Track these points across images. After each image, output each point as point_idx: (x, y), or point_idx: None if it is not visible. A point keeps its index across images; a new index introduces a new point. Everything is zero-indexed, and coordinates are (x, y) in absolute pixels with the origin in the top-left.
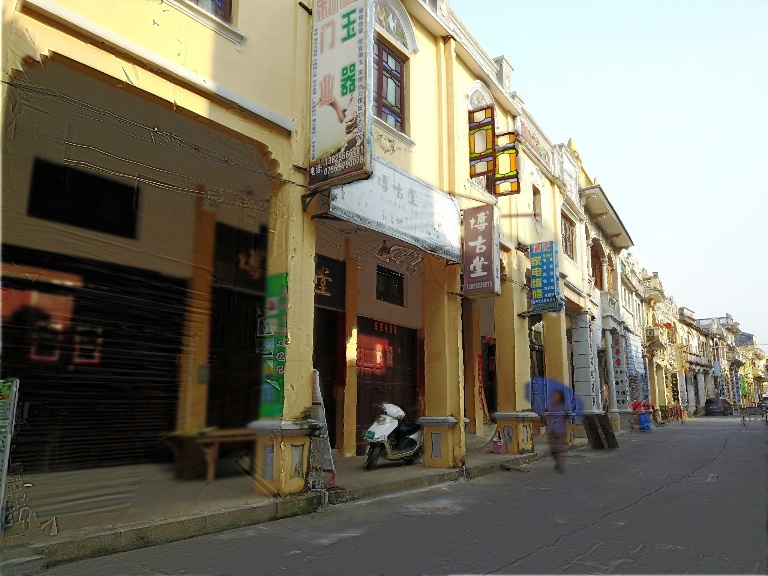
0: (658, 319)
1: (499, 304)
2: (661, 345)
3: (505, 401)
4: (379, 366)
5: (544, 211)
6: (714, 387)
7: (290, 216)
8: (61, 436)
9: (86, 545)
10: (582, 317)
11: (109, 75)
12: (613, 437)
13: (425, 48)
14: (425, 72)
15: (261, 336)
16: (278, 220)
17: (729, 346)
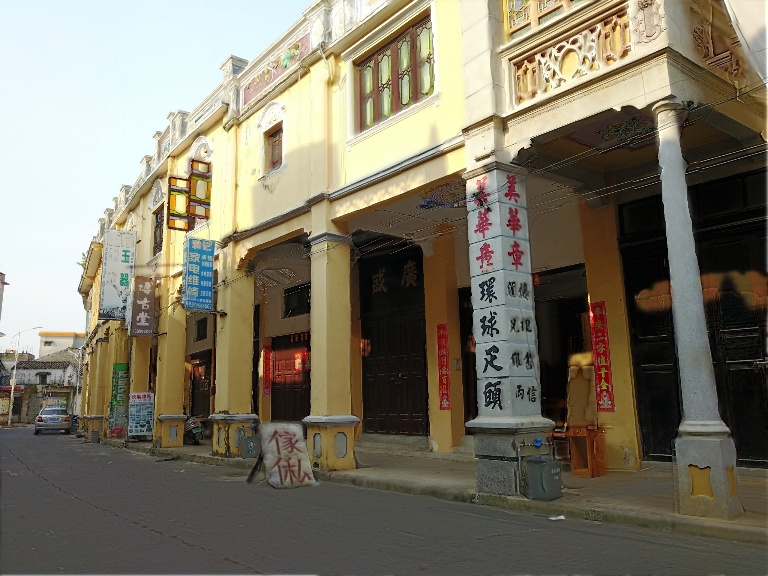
0: None
1: None
2: None
3: None
4: (297, 372)
5: (289, 138)
6: None
7: None
8: None
9: None
10: None
11: None
12: None
13: None
14: None
15: None
16: None
17: None
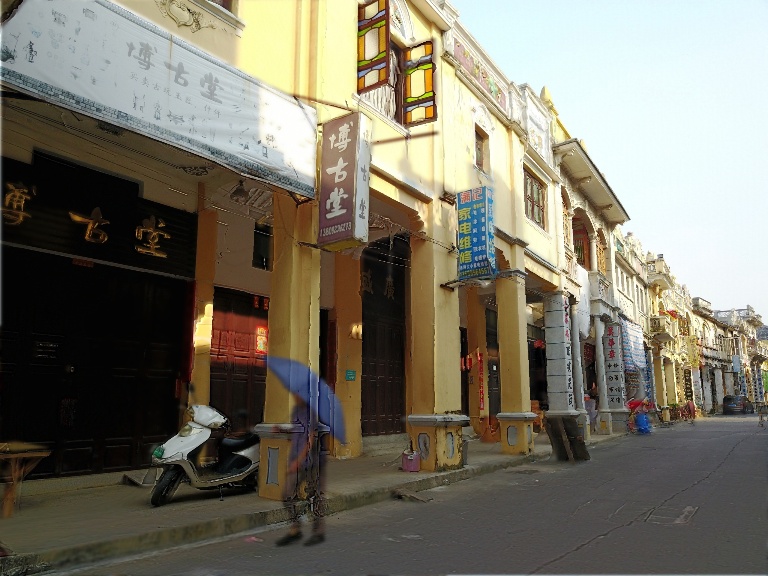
0: (667, 308)
1: (417, 272)
2: (667, 336)
3: (421, 400)
4: (261, 355)
5: (494, 161)
6: (733, 383)
7: None
8: None
9: None
10: (556, 298)
11: None
12: (582, 445)
13: None
14: None
15: None
16: None
17: (750, 340)
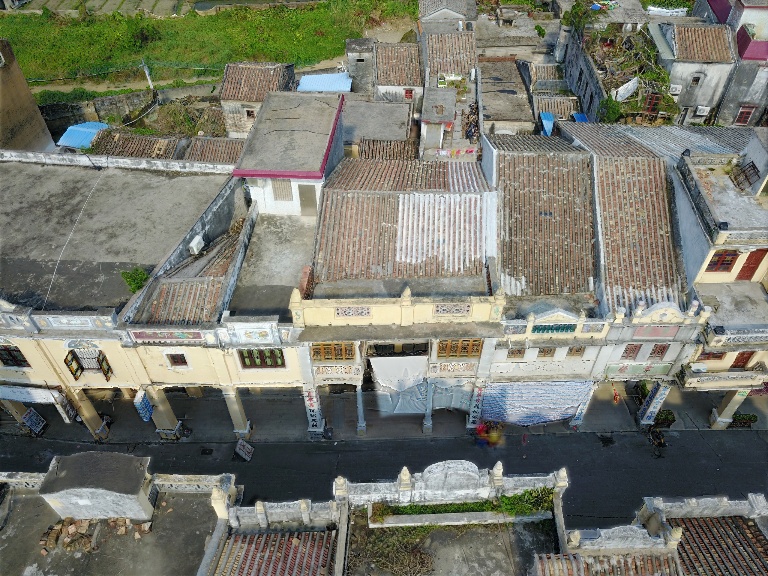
0: None
1: None
2: None
3: None
4: None
5: (192, 361)
6: None
7: None
8: None
9: None
10: None
11: None
12: (242, 457)
13: (24, 340)
14: (28, 348)
15: None
16: None
17: None
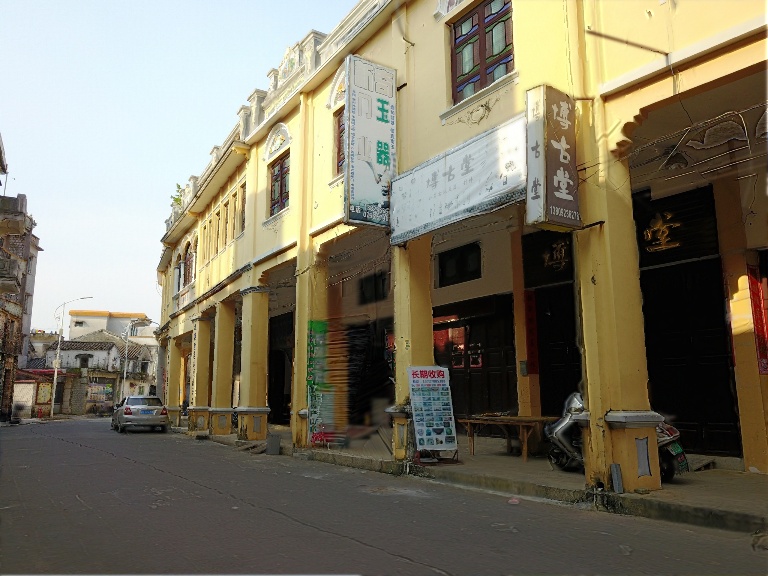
0: None
1: None
2: None
3: None
4: None
5: None
6: None
7: (395, 256)
8: (328, 408)
9: None
10: None
11: None
12: None
13: None
14: None
15: (387, 348)
16: None
17: None
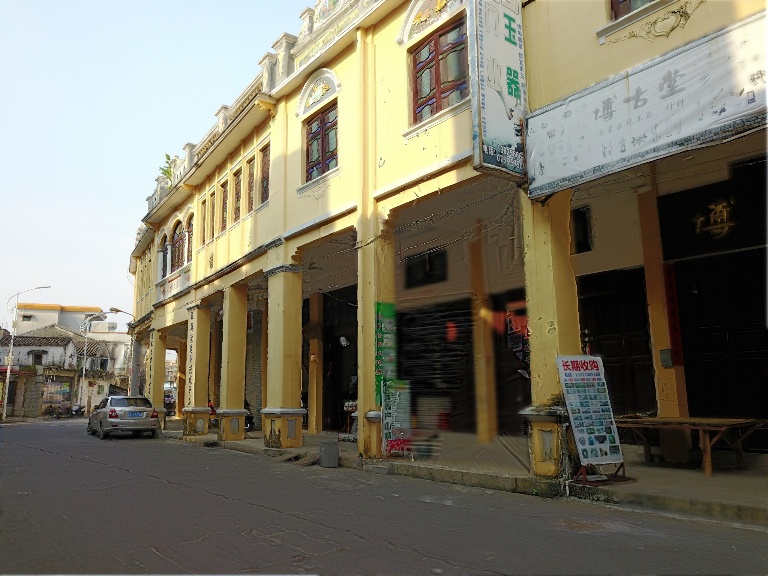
0: None
1: None
2: None
3: None
4: None
5: None
6: None
7: (523, 216)
8: (410, 410)
9: (407, 469)
10: None
11: (409, 202)
12: None
13: None
14: None
15: (512, 333)
16: (516, 225)
17: None
